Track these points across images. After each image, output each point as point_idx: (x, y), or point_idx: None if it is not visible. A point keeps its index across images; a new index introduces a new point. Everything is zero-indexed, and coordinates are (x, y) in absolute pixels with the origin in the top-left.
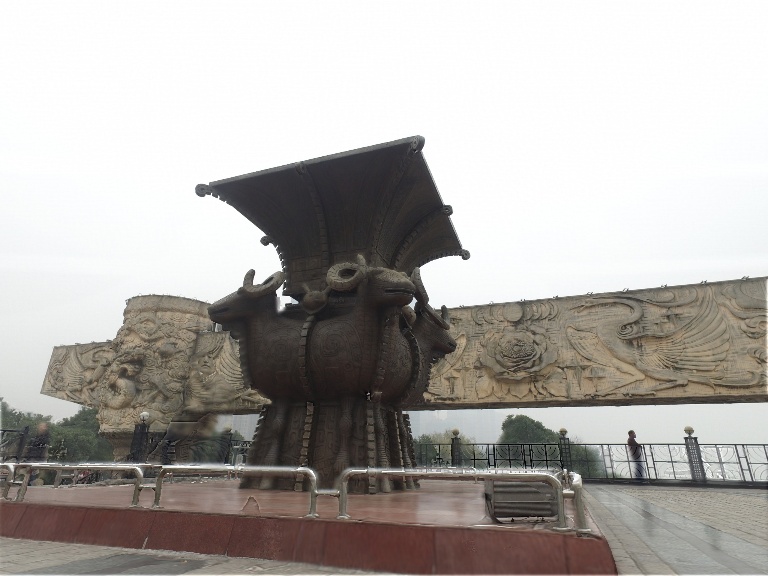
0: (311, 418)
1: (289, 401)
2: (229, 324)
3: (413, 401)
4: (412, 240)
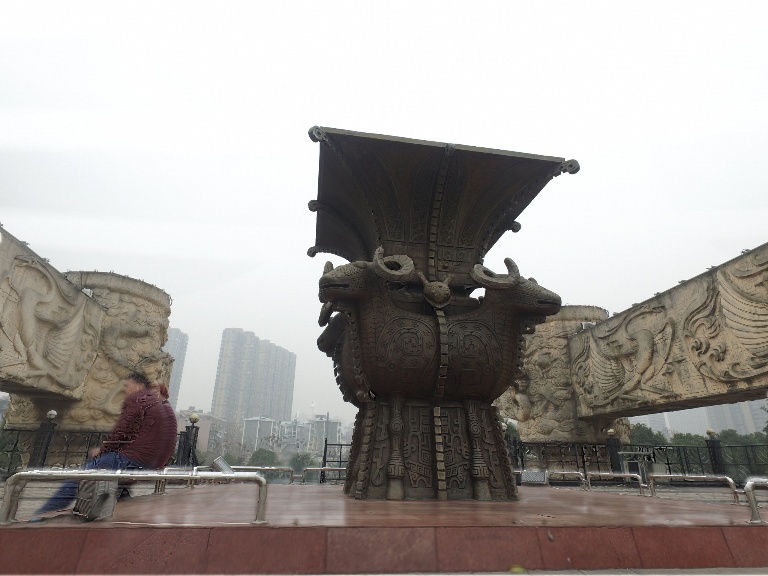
0: (356, 424)
1: (362, 409)
2: (330, 351)
3: (490, 389)
4: (453, 201)
